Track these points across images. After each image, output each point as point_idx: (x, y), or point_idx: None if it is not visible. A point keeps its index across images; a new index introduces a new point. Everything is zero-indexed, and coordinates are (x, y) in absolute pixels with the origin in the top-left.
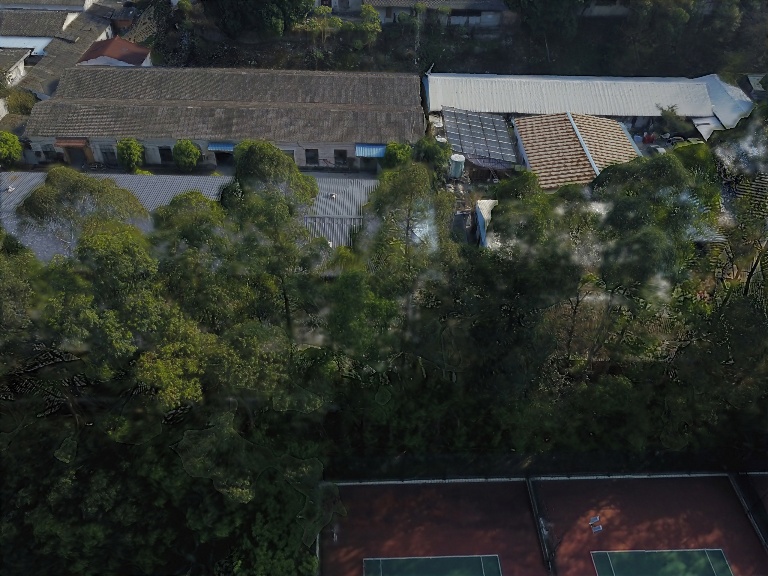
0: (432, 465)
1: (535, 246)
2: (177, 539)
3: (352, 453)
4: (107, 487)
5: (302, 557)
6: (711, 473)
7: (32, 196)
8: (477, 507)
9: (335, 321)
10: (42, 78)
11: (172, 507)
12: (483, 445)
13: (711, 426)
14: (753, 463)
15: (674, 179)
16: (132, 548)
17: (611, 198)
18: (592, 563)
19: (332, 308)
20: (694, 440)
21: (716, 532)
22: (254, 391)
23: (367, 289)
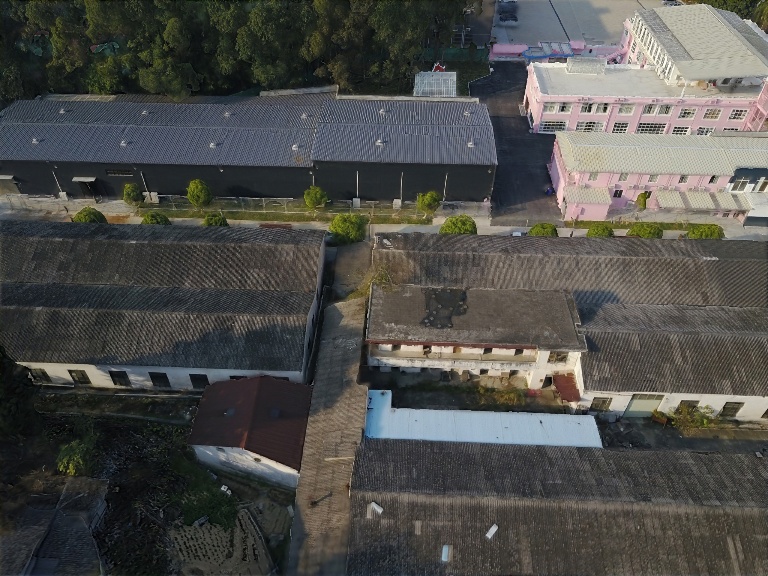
0: None
1: None
2: None
3: None
4: None
5: None
6: None
7: None
8: None
9: None
10: (344, 325)
11: None
12: None
13: None
14: None
15: None
16: None
17: None
18: None
19: None
20: None
21: None
22: None
23: None
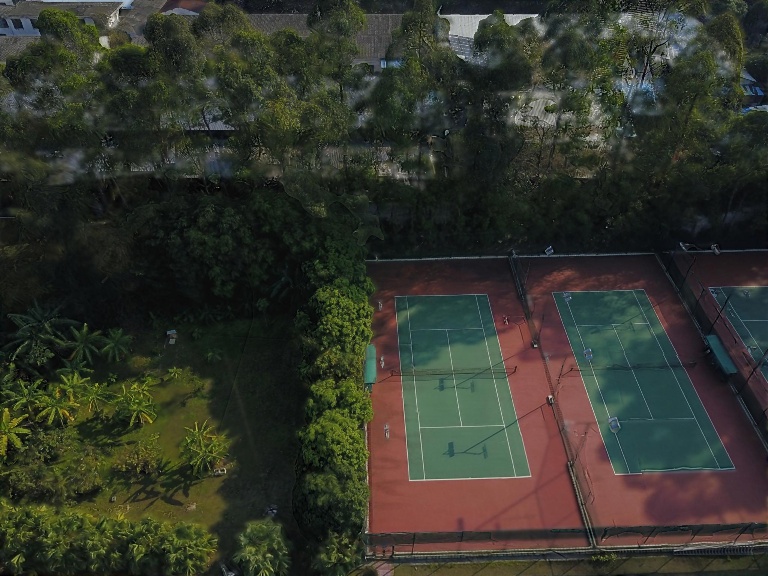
0: (442, 251)
1: (501, 52)
2: (274, 261)
3: (385, 241)
4: (234, 215)
5: (356, 263)
6: (642, 252)
7: (200, 14)
8: (473, 271)
9: (376, 100)
10: (133, 23)
11: (273, 232)
12: (477, 231)
13: (639, 214)
14: (671, 242)
15: (585, 2)
16: (247, 263)
17: (549, 23)
18: (552, 297)
19: (374, 93)
20: (627, 222)
21: (641, 281)
22: (320, 176)
23: (396, 78)
